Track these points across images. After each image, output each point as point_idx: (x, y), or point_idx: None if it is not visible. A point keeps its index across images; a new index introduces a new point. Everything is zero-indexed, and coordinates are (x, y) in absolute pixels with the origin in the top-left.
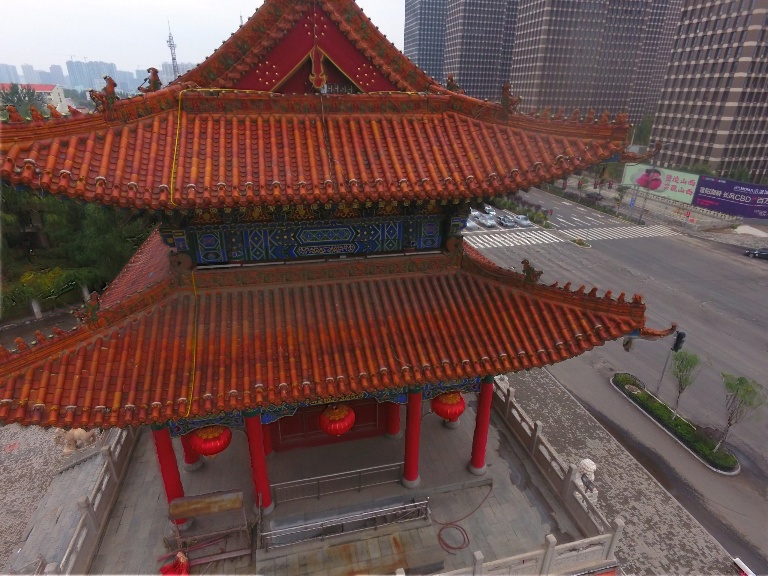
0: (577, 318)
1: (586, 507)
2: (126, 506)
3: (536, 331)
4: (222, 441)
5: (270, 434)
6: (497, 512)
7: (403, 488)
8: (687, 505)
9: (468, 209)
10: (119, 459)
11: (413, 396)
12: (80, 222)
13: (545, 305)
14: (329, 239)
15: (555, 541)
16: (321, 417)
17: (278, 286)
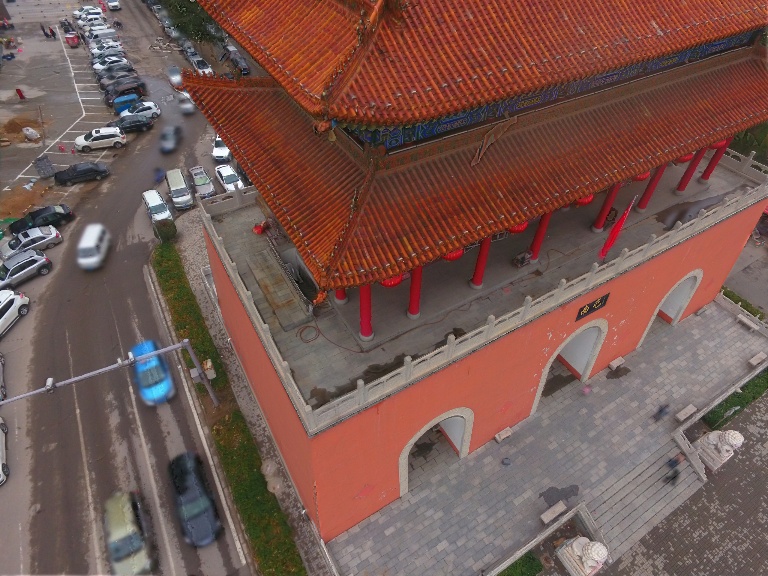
0: None
1: (569, 571)
2: None
3: None
4: None
5: None
6: (337, 357)
7: None
8: None
9: None
10: None
11: None
12: None
13: None
14: None
15: (283, 366)
16: None
17: None
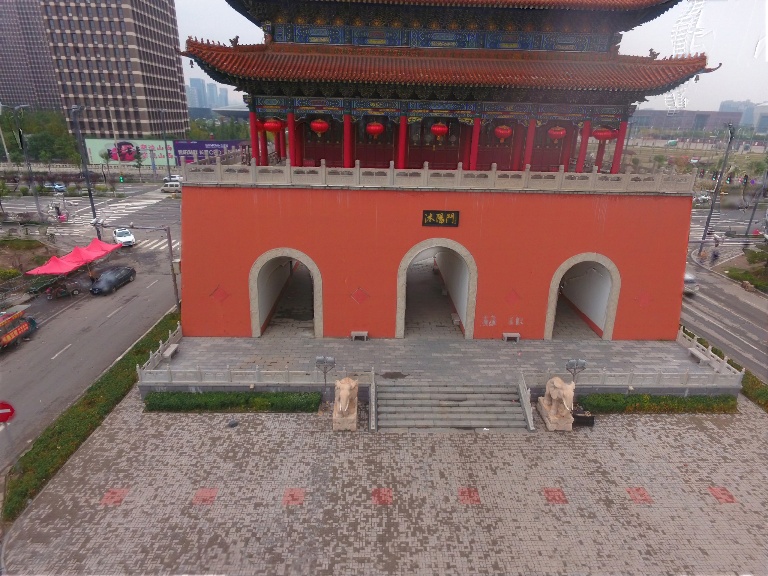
0: None
1: None
2: None
3: None
4: None
5: None
6: None
7: None
8: None
9: None
10: None
11: None
12: None
13: None
14: None
15: None
16: None
17: None
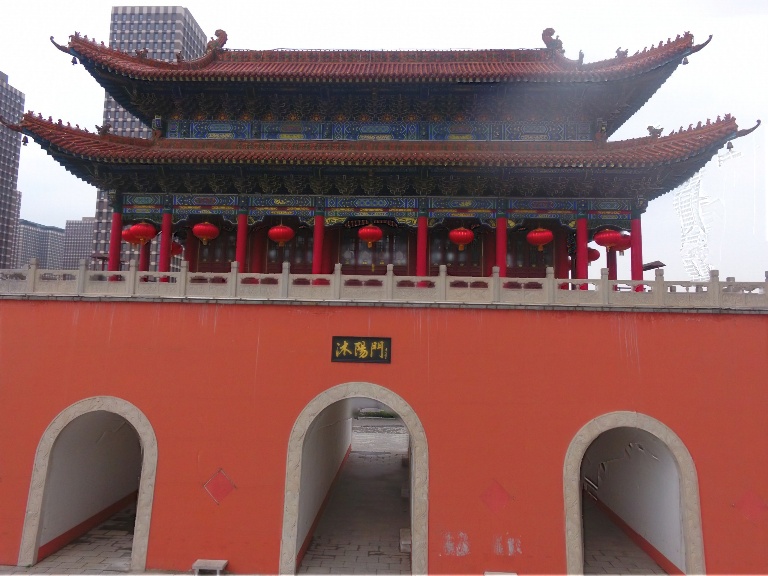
0: None
1: None
2: None
3: None
4: None
5: None
6: None
7: None
8: None
9: None
10: None
11: None
12: None
13: None
14: None
15: None
16: (593, 250)
17: None
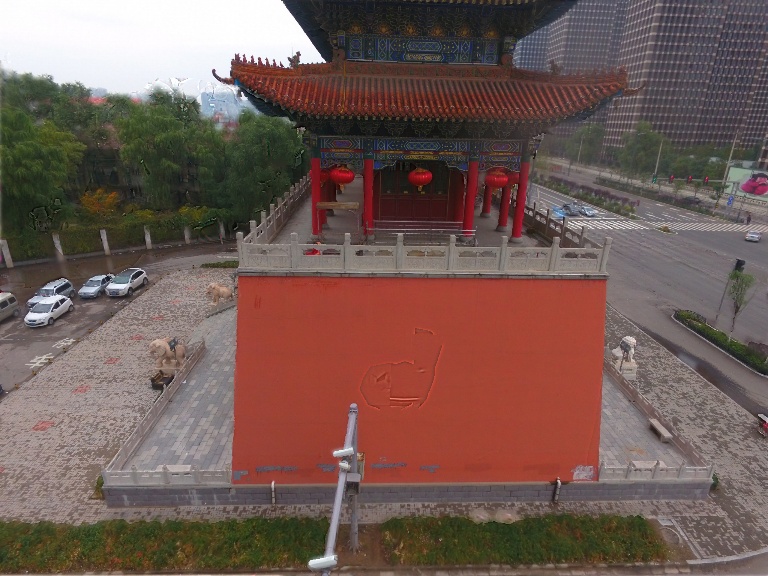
0: (583, 90)
1: None
2: (282, 239)
3: (555, 100)
4: (349, 175)
5: (373, 211)
6: None
7: (461, 242)
8: (726, 391)
9: (516, 28)
10: (277, 222)
11: (472, 164)
12: (226, 169)
13: (564, 88)
14: (426, 49)
15: None
16: (410, 173)
17: (392, 77)
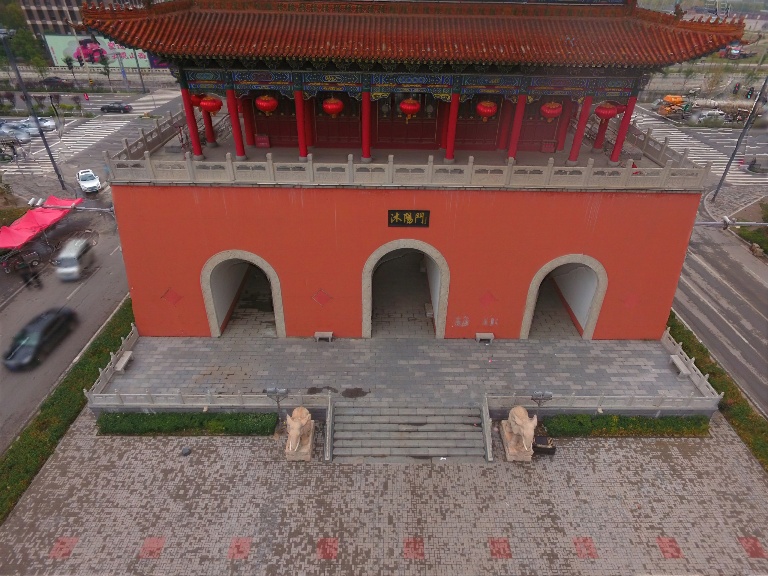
0: None
1: None
2: None
3: None
4: None
5: None
6: None
7: None
8: None
9: None
10: None
11: None
12: None
13: None
14: None
15: None
16: None
17: None
